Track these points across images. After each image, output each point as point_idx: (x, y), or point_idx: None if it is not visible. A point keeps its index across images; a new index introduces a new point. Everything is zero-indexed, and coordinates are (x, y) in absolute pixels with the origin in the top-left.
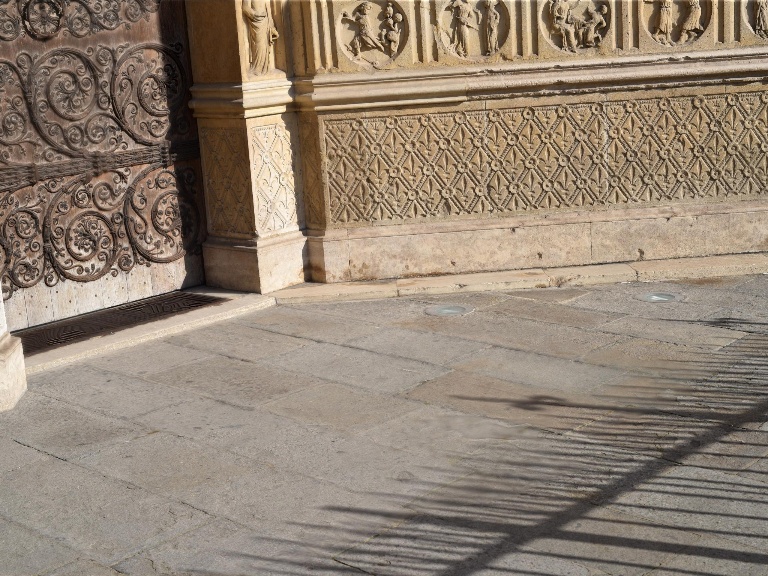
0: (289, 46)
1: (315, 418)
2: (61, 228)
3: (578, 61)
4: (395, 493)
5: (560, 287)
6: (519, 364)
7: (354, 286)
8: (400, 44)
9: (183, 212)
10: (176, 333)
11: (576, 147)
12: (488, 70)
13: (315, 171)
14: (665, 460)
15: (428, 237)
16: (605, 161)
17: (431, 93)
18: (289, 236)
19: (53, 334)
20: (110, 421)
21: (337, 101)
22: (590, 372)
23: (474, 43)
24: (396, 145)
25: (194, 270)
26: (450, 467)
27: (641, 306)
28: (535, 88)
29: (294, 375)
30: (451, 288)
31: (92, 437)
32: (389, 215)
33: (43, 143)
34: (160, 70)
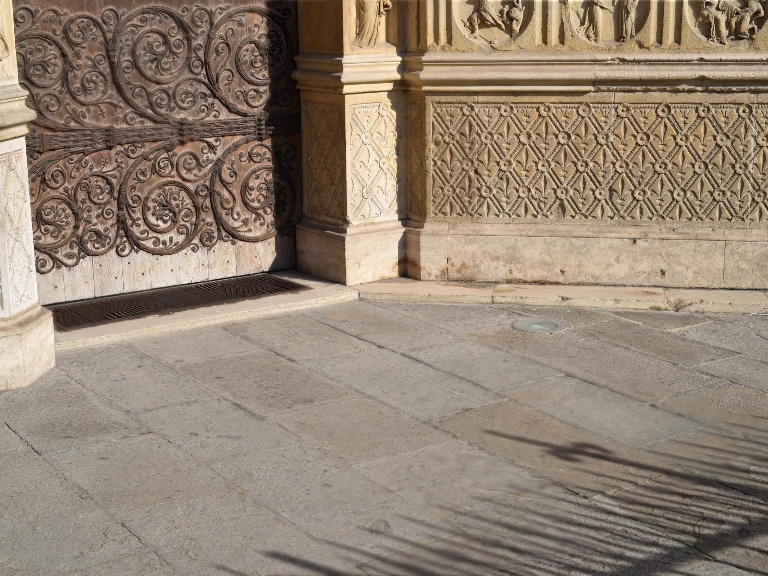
0: (403, 18)
1: (323, 439)
2: (138, 196)
3: (727, 54)
4: (356, 547)
5: (678, 311)
6: (585, 400)
7: (448, 287)
8: (523, 23)
9: (277, 189)
10: (239, 320)
11: (716, 153)
12: (620, 58)
13: (420, 157)
14: (696, 550)
15: (536, 240)
16: (749, 172)
17: (552, 80)
18: (385, 225)
19: (117, 307)
20: (111, 413)
21: (447, 82)
22: (661, 421)
23: (607, 27)
24: (510, 135)
25: (285, 252)
26: (435, 523)
27: (760, 345)
28: (673, 82)
29: (331, 383)
30: (552, 300)
31: (82, 430)
32: (496, 212)
33: (125, 105)
34: (263, 36)
